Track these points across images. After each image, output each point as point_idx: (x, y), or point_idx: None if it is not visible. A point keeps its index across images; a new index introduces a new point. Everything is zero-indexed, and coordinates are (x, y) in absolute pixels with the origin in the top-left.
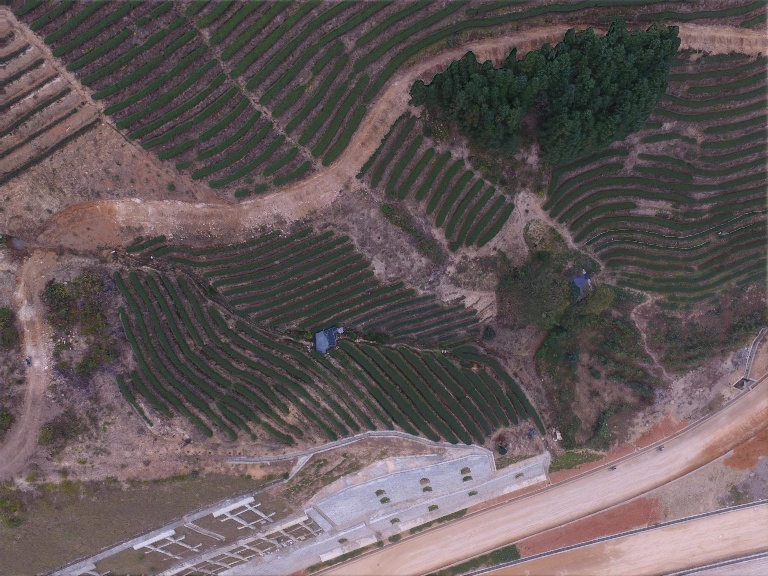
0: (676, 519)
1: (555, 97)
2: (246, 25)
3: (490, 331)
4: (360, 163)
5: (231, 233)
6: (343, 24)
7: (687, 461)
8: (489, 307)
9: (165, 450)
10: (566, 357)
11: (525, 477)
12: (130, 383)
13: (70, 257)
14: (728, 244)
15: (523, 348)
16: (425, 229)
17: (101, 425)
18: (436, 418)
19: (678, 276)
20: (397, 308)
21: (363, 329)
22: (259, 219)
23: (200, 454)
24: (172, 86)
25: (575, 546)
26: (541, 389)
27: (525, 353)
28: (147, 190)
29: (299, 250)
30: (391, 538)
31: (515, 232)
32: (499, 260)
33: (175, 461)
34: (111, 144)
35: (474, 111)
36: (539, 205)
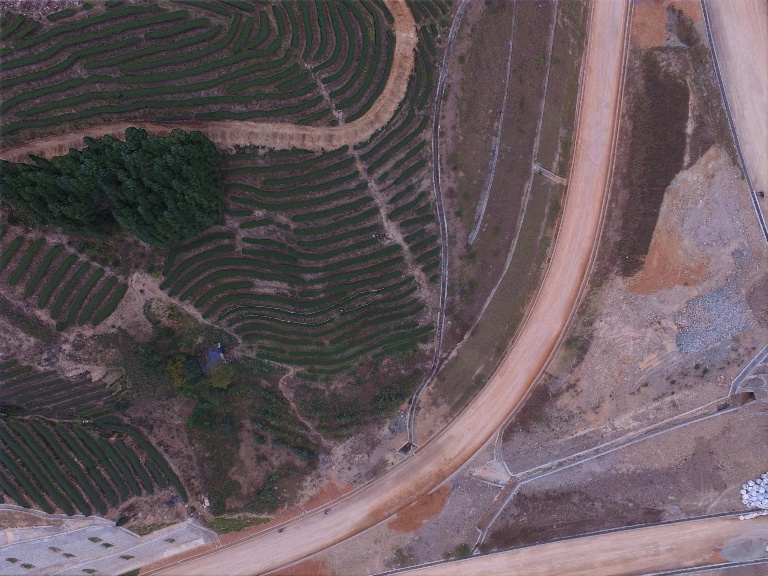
0: None
1: None
2: None
3: (120, 404)
4: None
5: None
6: None
7: (353, 524)
8: None
9: None
10: None
11: (182, 541)
12: None
13: None
14: (353, 320)
15: (176, 416)
16: (27, 311)
17: None
18: (55, 490)
19: (313, 350)
20: (19, 383)
21: None
22: None
23: None
24: None
25: None
26: (192, 456)
27: (178, 421)
28: None
29: None
30: None
31: (134, 310)
32: (121, 337)
33: None
34: None
35: (22, 209)
36: (157, 284)
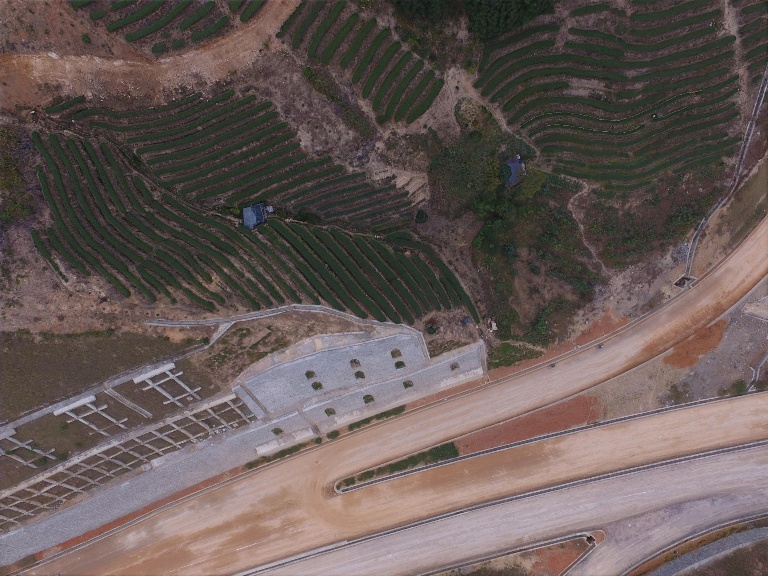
0: (615, 418)
1: None
2: None
3: (422, 213)
4: (280, 21)
5: (151, 94)
6: None
7: (627, 359)
8: (422, 190)
9: (80, 306)
10: (503, 249)
11: (461, 370)
12: (46, 240)
13: None
14: (663, 128)
15: (460, 238)
16: (351, 100)
17: (14, 277)
18: (364, 296)
19: (614, 163)
20: (326, 186)
21: (293, 208)
22: (178, 78)
23: (116, 313)
24: None
25: (514, 444)
26: (477, 279)
27: (461, 243)
28: (63, 43)
29: (222, 115)
30: (329, 434)
31: (446, 110)
32: (430, 139)
33: (91, 318)
34: None
35: None
36: (470, 83)
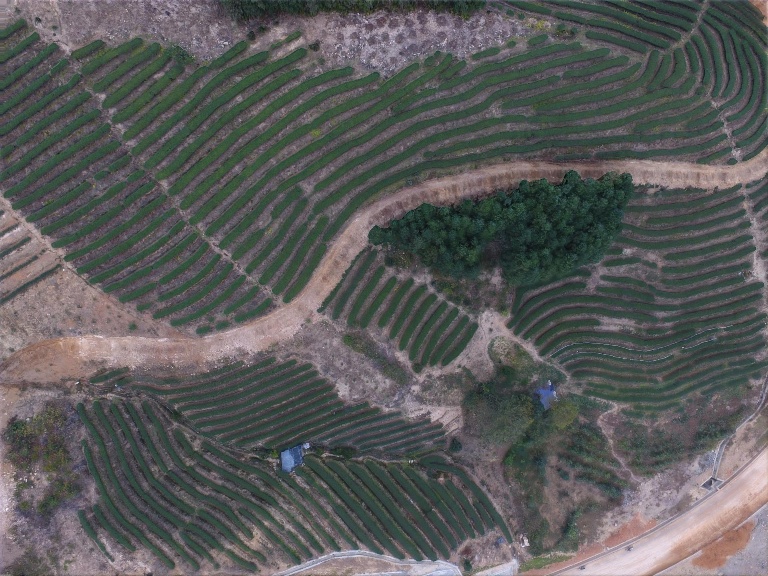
0: None
1: (513, 236)
2: (204, 175)
3: (456, 444)
4: (321, 298)
5: (194, 365)
6: (302, 170)
7: (656, 561)
8: (455, 420)
9: None
10: (534, 461)
11: None
12: (92, 518)
13: (33, 391)
14: (692, 357)
15: (491, 454)
16: (388, 353)
17: (62, 564)
18: (401, 535)
19: (643, 386)
20: (362, 425)
21: (329, 444)
22: (221, 353)
23: None
24: (132, 233)
25: None
26: (509, 495)
27: (493, 459)
28: (109, 328)
29: (262, 378)
30: None
31: (479, 349)
32: (464, 376)
33: None
34: (72, 288)
35: (432, 253)
36: (503, 323)
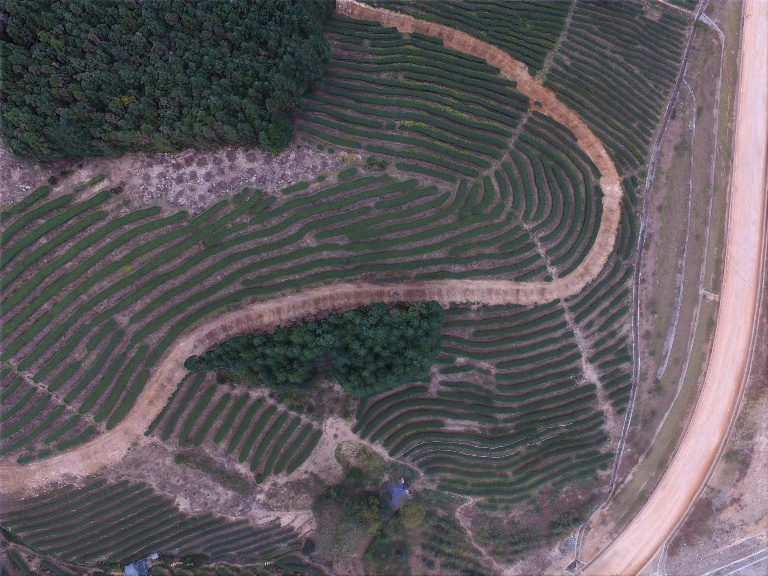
0: None
1: (333, 359)
2: (12, 314)
3: (308, 547)
4: (147, 421)
5: (20, 491)
6: (116, 303)
7: None
8: (308, 522)
9: None
10: (396, 554)
11: None
12: None
13: None
14: (538, 452)
15: None
16: (228, 466)
17: None
18: None
19: (495, 481)
20: (210, 534)
21: None
22: (46, 479)
23: None
24: None
25: None
26: None
27: (354, 554)
28: None
29: (95, 499)
30: None
31: (326, 455)
32: (312, 481)
33: None
34: None
35: (250, 379)
36: (349, 427)
